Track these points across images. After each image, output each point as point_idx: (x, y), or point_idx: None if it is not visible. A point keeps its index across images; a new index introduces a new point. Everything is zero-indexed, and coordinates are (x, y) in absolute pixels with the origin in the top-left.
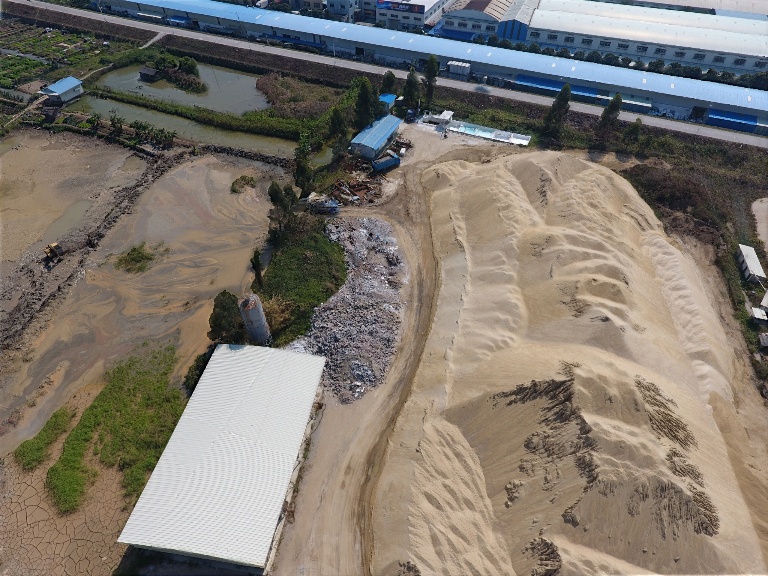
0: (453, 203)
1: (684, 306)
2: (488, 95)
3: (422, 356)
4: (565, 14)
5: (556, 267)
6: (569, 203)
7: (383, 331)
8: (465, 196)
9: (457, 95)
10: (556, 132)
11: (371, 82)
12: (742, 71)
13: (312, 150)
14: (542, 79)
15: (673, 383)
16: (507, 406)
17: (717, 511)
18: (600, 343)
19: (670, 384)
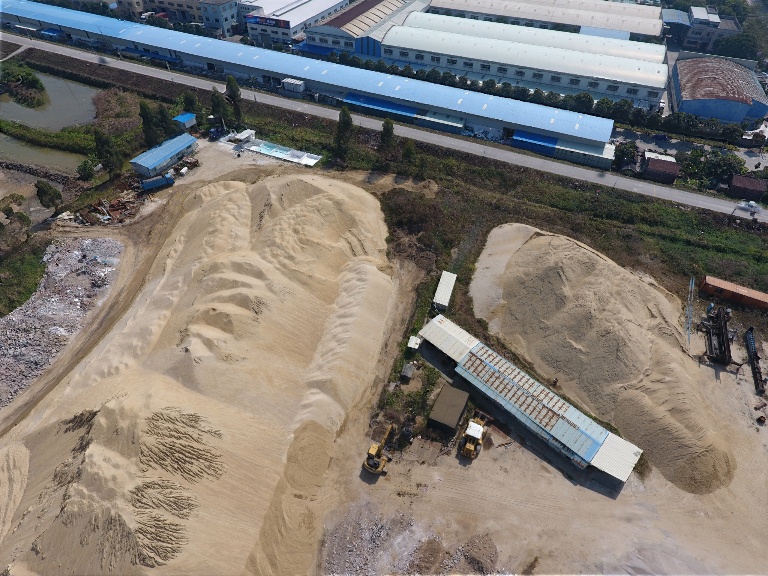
0: (187, 225)
1: (337, 334)
2: (304, 114)
3: (62, 379)
4: (422, 31)
5: (201, 295)
6: (273, 229)
7: (34, 354)
8: (197, 219)
9: (276, 113)
10: (343, 153)
11: (202, 99)
12: (578, 91)
13: (103, 168)
14: (369, 97)
15: (248, 413)
16: (64, 433)
17: (186, 542)
18: (175, 373)
19: (240, 414)
